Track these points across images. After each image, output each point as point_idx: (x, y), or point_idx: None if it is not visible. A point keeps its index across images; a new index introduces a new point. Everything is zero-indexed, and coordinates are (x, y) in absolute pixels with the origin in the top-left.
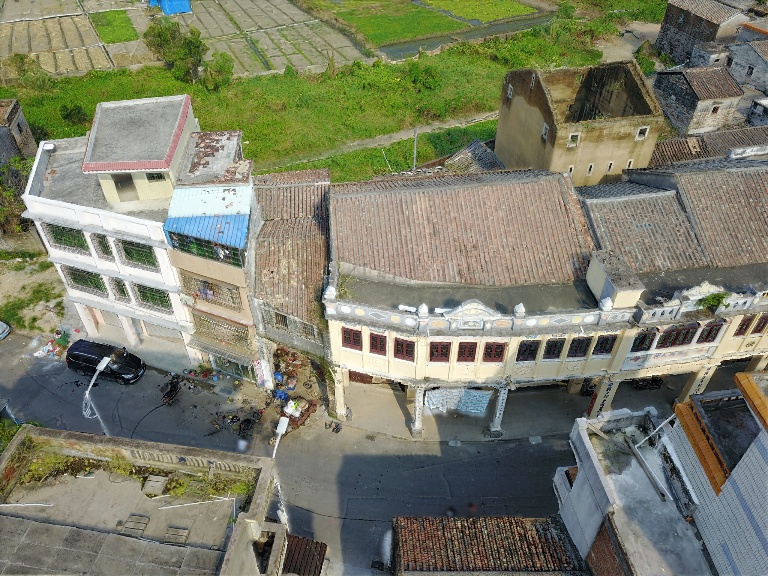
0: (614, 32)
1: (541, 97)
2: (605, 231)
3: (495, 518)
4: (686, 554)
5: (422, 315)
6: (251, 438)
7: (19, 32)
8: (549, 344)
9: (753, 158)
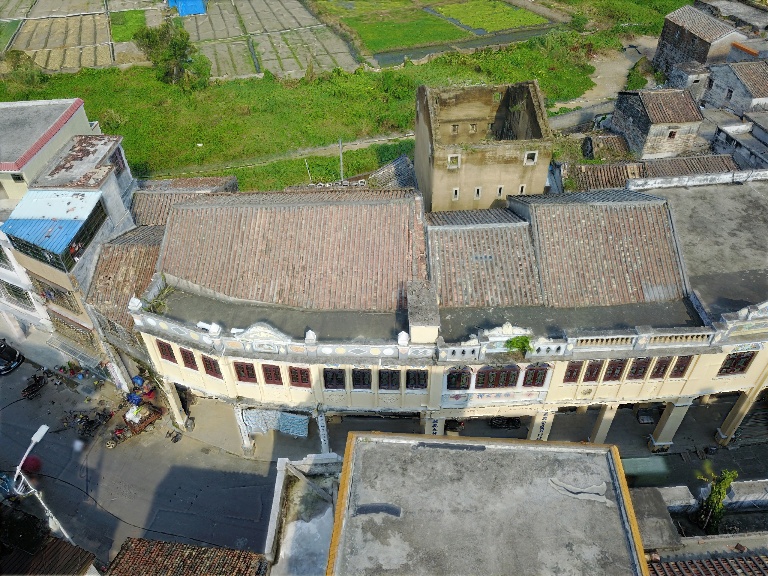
0: (617, 46)
1: (428, 115)
2: (439, 260)
3: (227, 550)
4: None
5: (212, 334)
6: (92, 439)
7: (41, 28)
8: (356, 374)
9: (656, 191)
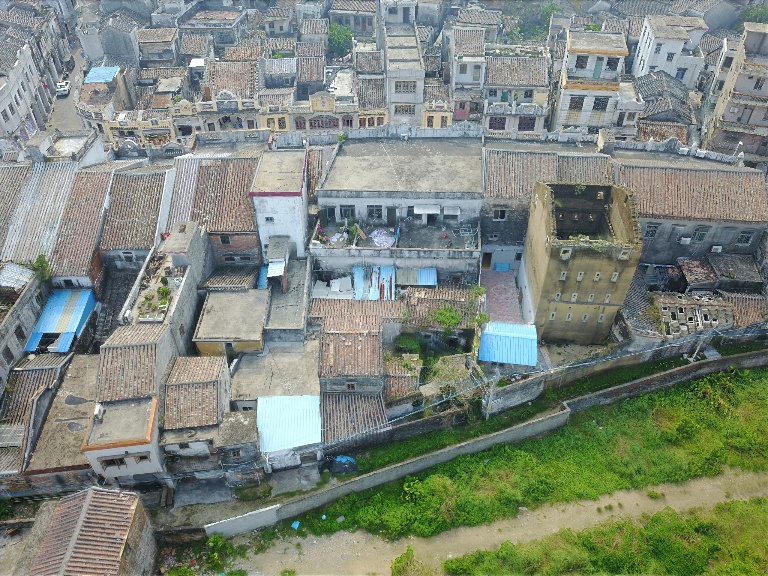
0: None
1: None
2: None
3: (654, 141)
4: (620, 93)
5: None
6: None
7: None
8: None
9: None
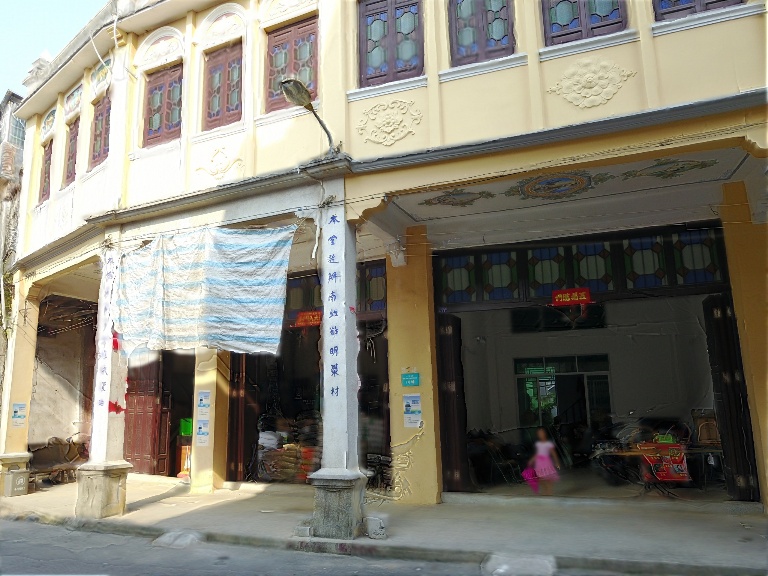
0: None
1: None
2: None
3: None
4: None
5: None
6: None
7: None
8: (462, 5)
9: None
